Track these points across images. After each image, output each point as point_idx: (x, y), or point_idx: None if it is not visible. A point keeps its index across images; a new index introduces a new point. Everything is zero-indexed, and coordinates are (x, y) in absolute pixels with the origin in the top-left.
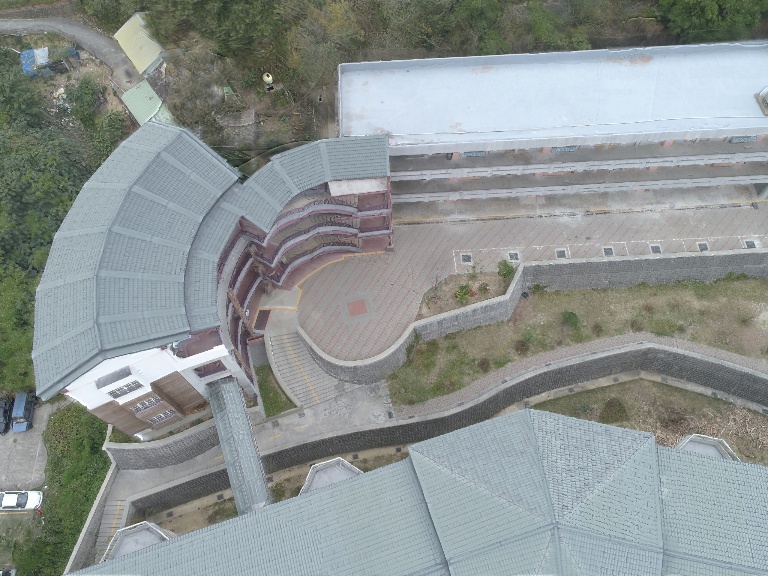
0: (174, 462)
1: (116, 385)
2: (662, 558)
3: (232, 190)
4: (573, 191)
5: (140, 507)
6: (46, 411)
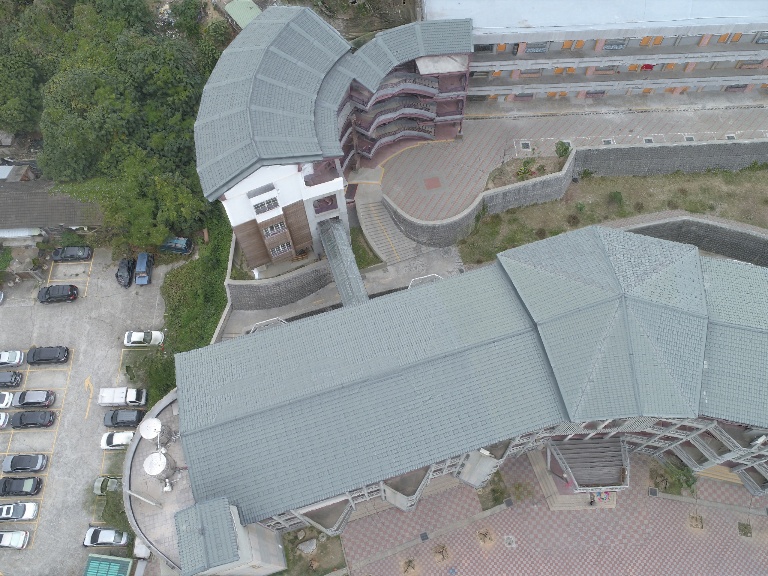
0: (279, 304)
1: (262, 198)
2: (707, 322)
3: (345, 58)
4: (619, 87)
5: None
6: (162, 270)
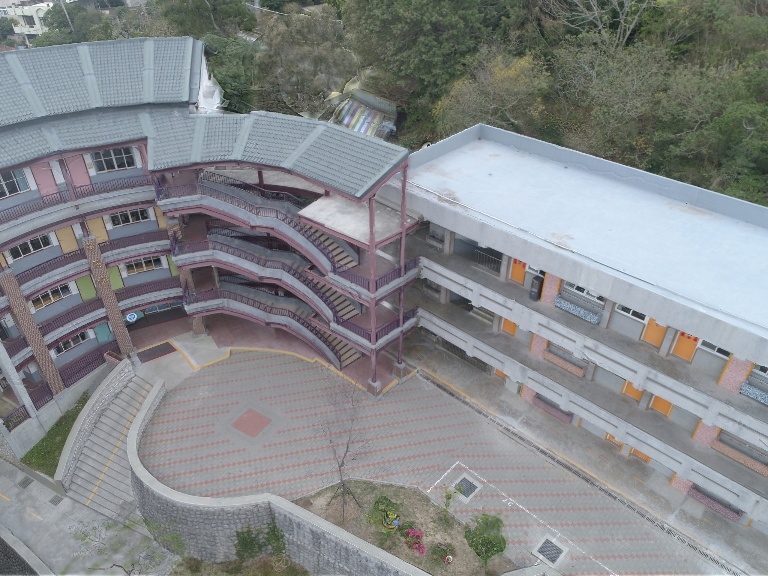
0: None
1: None
2: None
3: (172, 111)
4: (759, 514)
5: None
6: None
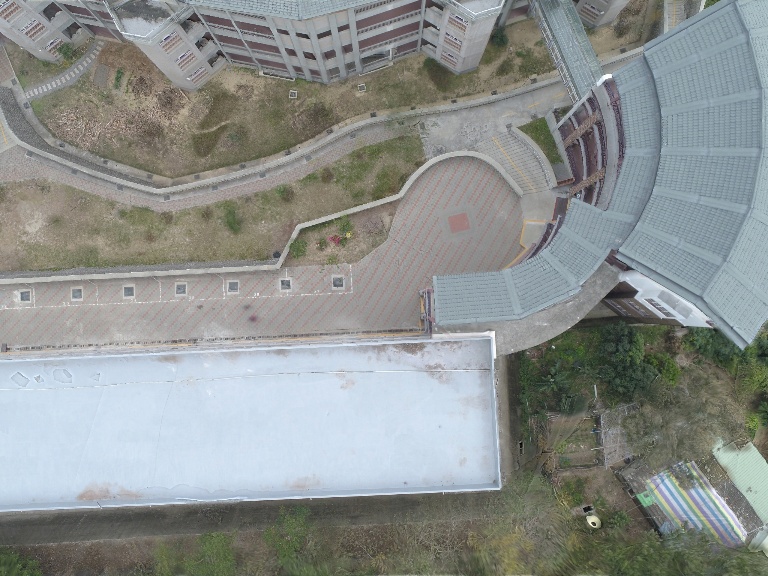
0: None
1: None
2: None
3: (623, 239)
4: None
5: None
6: None
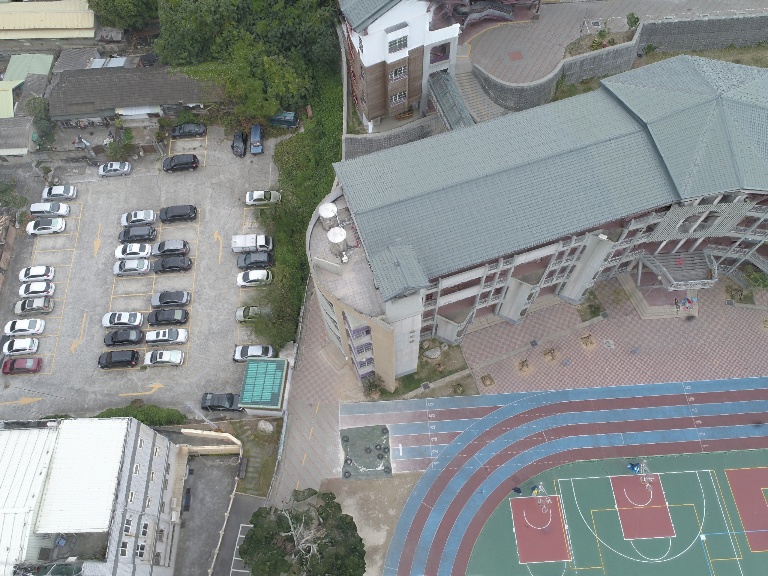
0: None
1: (397, 35)
2: None
3: None
4: None
5: None
6: (272, 142)
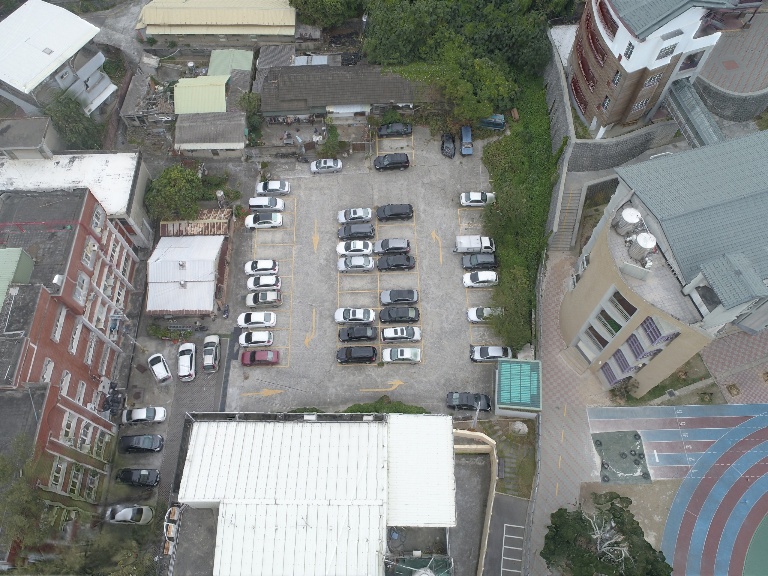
0: (608, 166)
1: (671, 42)
2: None
3: None
4: None
5: (587, 195)
6: (479, 144)
